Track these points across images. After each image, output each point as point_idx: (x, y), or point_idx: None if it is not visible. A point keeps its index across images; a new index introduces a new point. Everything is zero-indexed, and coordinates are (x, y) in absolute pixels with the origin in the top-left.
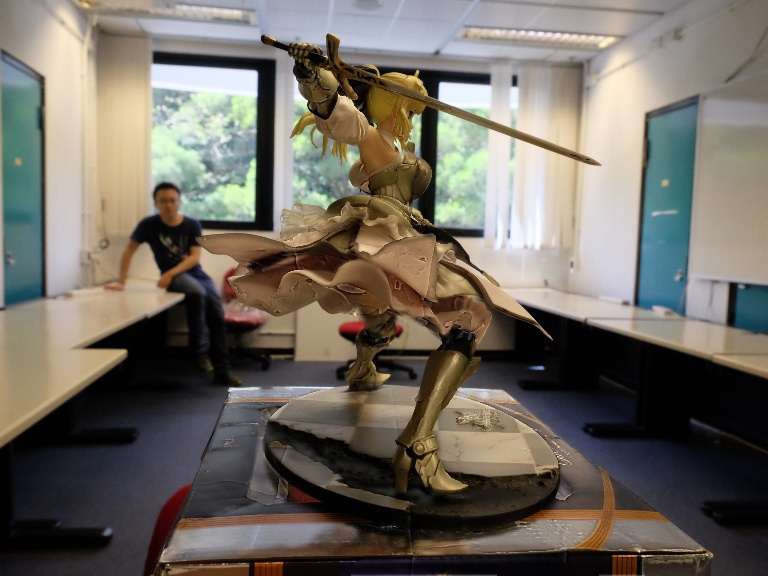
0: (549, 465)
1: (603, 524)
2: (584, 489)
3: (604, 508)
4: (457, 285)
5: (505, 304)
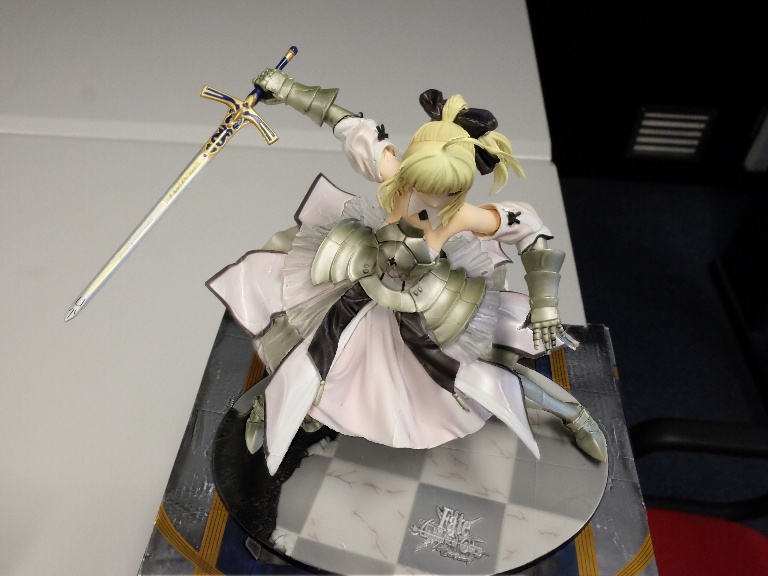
0: (293, 548)
1: (189, 550)
2: (259, 574)
3: (217, 570)
4: (277, 352)
5: (272, 405)
